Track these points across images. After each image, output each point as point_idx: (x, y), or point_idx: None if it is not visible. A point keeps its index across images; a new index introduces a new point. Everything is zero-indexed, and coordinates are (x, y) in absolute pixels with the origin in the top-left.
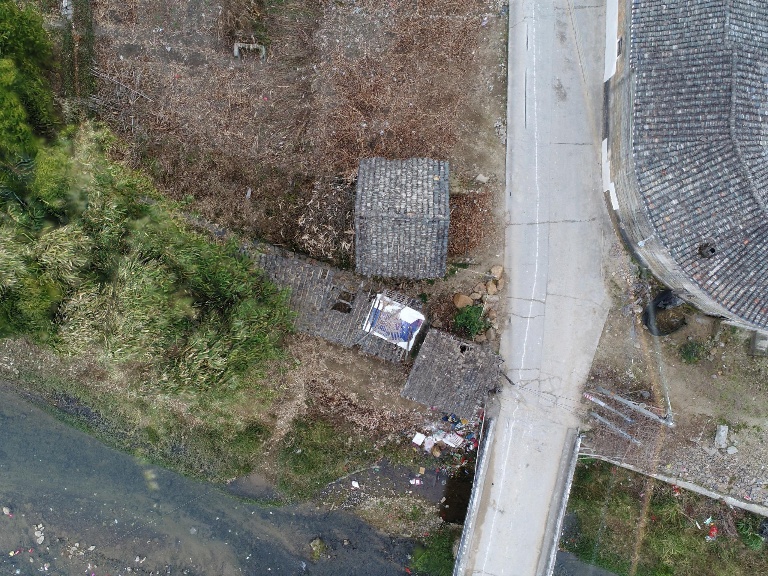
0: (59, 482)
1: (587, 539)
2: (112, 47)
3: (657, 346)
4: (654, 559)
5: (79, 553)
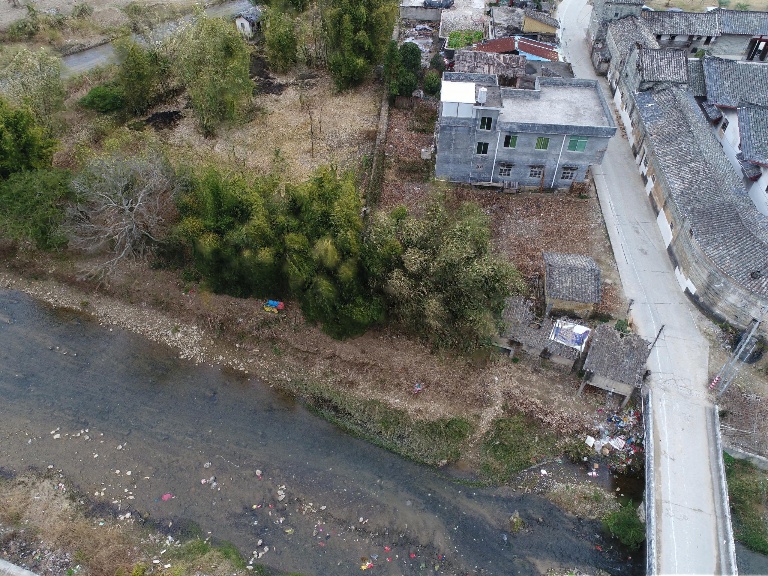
0: (303, 458)
1: (750, 529)
2: None
3: (750, 370)
4: None
5: (312, 510)
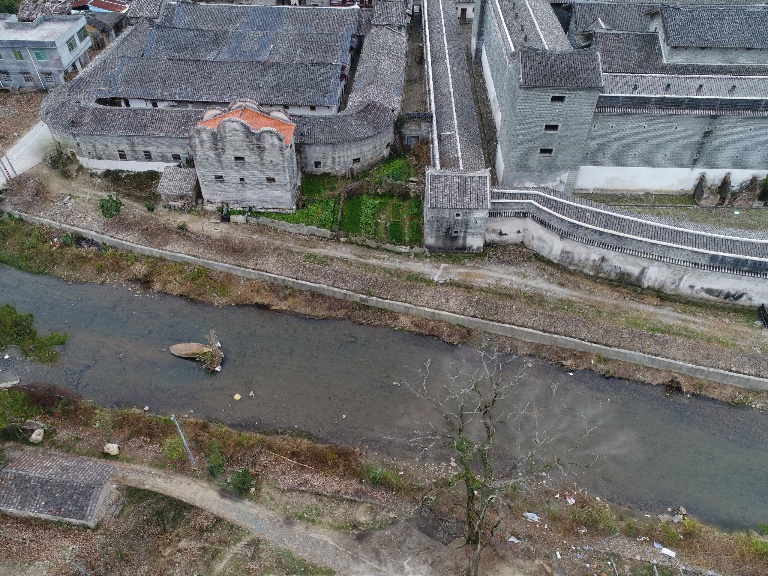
0: None
1: None
2: None
3: (54, 173)
4: None
5: None
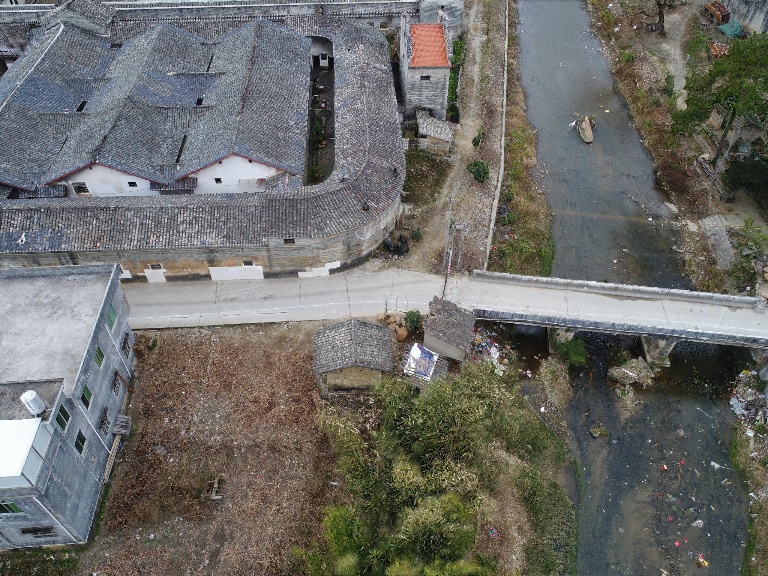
0: None
1: None
2: None
3: (415, 251)
4: (535, 256)
5: None
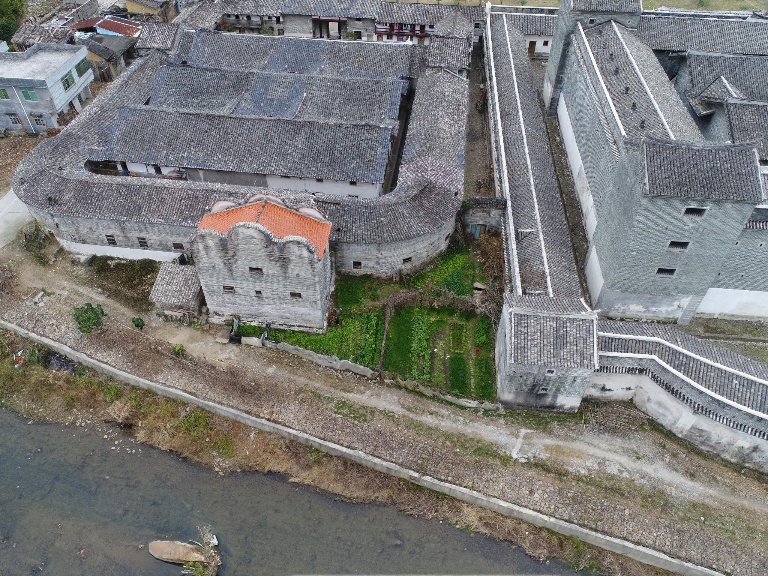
0: None
1: None
2: None
3: (28, 257)
4: None
5: None
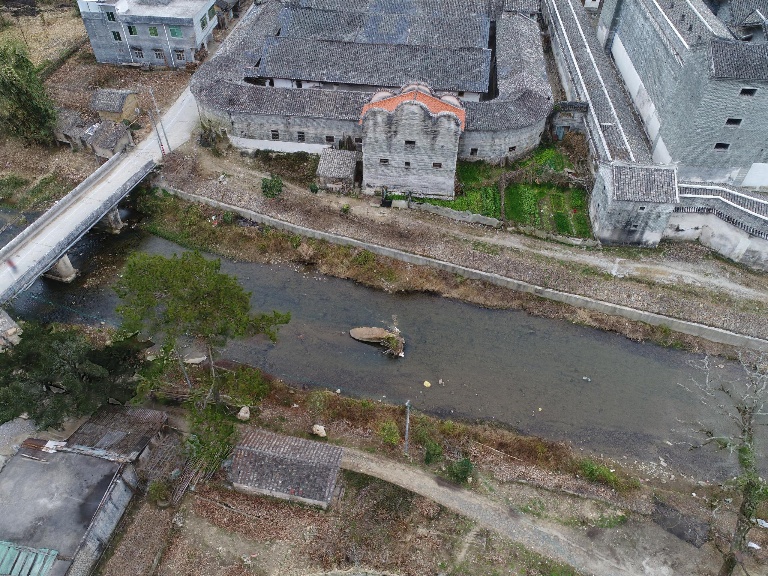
0: None
1: None
2: (47, 86)
3: (204, 151)
4: None
5: None
